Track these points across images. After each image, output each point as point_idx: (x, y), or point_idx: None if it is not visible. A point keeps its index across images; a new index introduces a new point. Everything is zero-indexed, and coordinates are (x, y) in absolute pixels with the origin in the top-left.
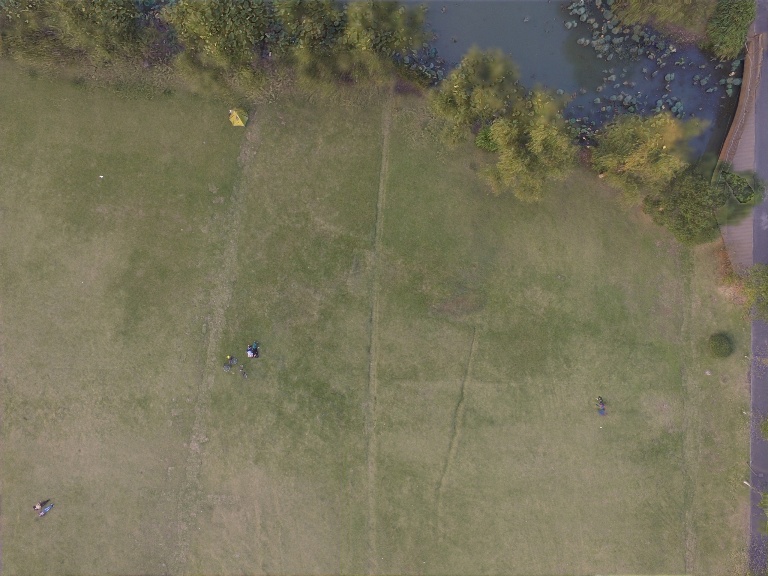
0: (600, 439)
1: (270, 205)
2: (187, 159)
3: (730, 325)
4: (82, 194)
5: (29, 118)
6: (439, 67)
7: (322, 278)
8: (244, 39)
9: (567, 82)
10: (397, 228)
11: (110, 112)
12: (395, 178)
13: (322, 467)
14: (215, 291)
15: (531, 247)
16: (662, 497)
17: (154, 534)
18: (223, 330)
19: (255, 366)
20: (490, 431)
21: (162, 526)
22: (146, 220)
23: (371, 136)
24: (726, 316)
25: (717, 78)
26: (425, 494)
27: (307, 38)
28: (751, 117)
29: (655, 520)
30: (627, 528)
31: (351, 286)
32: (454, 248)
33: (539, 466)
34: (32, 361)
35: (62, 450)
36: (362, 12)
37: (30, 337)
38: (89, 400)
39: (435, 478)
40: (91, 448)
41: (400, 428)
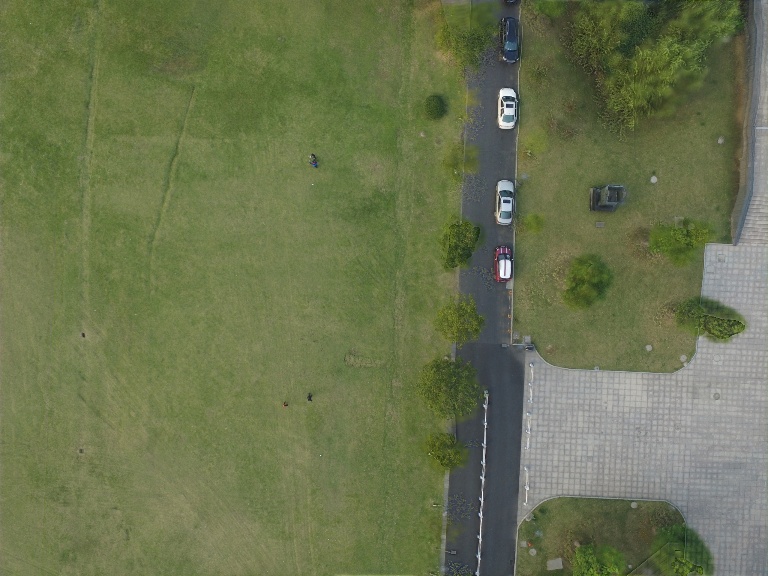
0: (311, 195)
1: None
2: None
3: (446, 88)
4: None
5: None
6: None
7: (43, 34)
8: None
9: None
10: None
11: None
12: None
13: (36, 218)
14: None
15: (254, 10)
16: (372, 255)
17: None
18: None
19: None
20: (202, 185)
21: None
22: None
23: None
24: (443, 79)
25: None
26: (138, 247)
27: None
28: None
29: (365, 278)
30: (337, 285)
31: (72, 43)
32: (178, 9)
33: (250, 221)
34: None
35: None
36: None
37: None
38: None
39: (148, 231)
40: None
41: (114, 181)
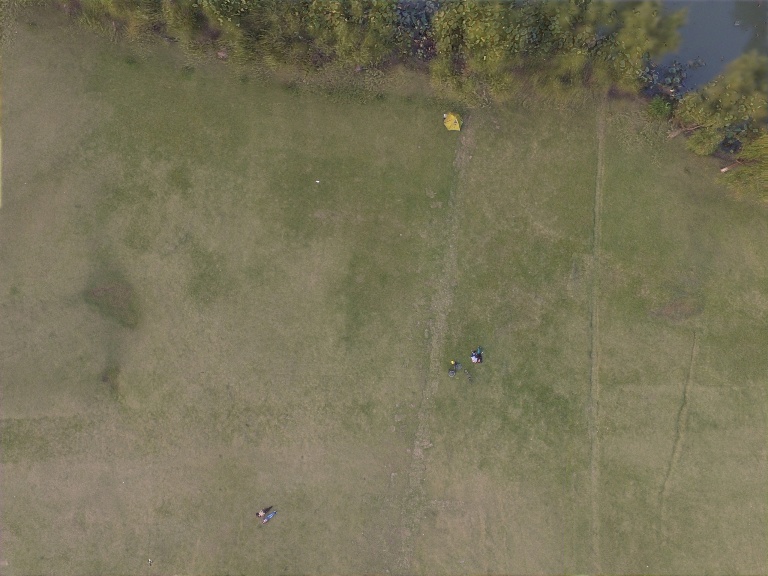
0: None
1: (489, 210)
2: (403, 164)
3: None
4: (299, 199)
5: (241, 123)
6: (654, 71)
7: (543, 283)
8: (460, 43)
9: None
10: (615, 232)
11: (323, 116)
12: (612, 182)
13: (546, 472)
14: (436, 296)
15: (748, 251)
16: None
17: (377, 540)
18: (446, 335)
19: (479, 371)
20: (714, 435)
21: (385, 532)
22: (365, 225)
23: (586, 140)
24: None
25: None
26: (648, 498)
27: (522, 42)
28: None
29: None
30: None
31: (571, 291)
32: (671, 252)
33: (762, 469)
34: (254, 367)
35: (285, 457)
36: (575, 16)
37: (252, 343)
38: (312, 406)
39: (658, 482)
40: (314, 454)
41: (624, 432)
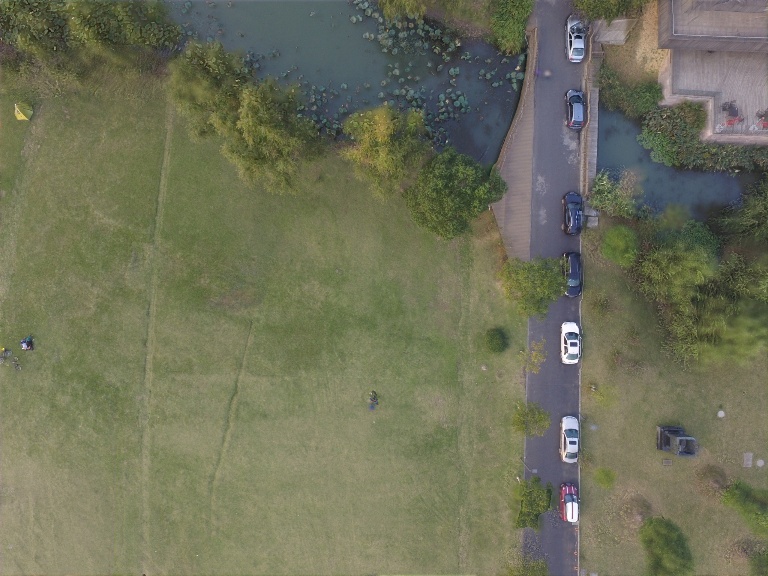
0: (373, 433)
1: (50, 198)
2: None
3: (507, 320)
4: None
5: None
6: (222, 61)
7: (100, 271)
8: (28, 33)
9: (351, 76)
10: (177, 222)
11: None
12: (176, 172)
13: (96, 459)
14: None
15: (310, 241)
16: (436, 492)
17: None
18: None
19: (30, 358)
20: (263, 425)
21: None
22: None
23: (154, 130)
24: (503, 311)
25: (503, 72)
26: (198, 487)
27: (91, 32)
28: (529, 111)
29: (429, 515)
30: (400, 523)
31: (129, 279)
32: (234, 242)
33: (311, 460)
34: None
35: None
36: (147, 7)
37: None
38: None
39: (208, 471)
40: None
41: (174, 421)
